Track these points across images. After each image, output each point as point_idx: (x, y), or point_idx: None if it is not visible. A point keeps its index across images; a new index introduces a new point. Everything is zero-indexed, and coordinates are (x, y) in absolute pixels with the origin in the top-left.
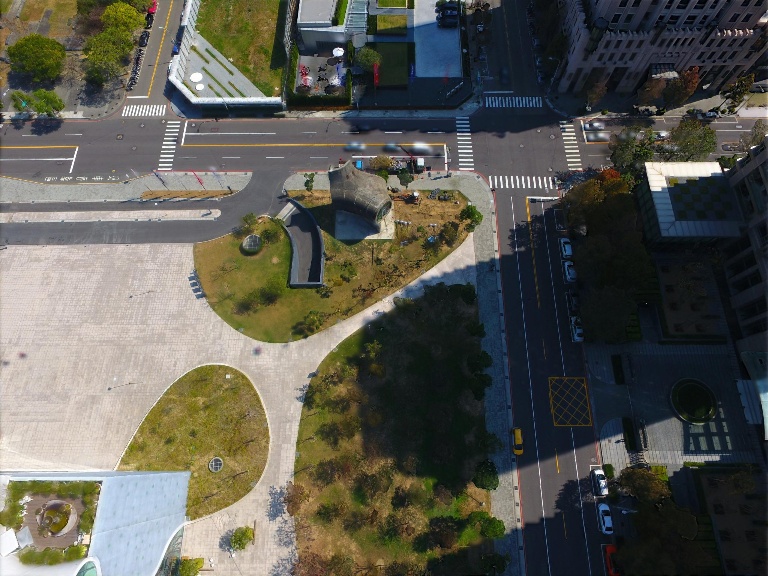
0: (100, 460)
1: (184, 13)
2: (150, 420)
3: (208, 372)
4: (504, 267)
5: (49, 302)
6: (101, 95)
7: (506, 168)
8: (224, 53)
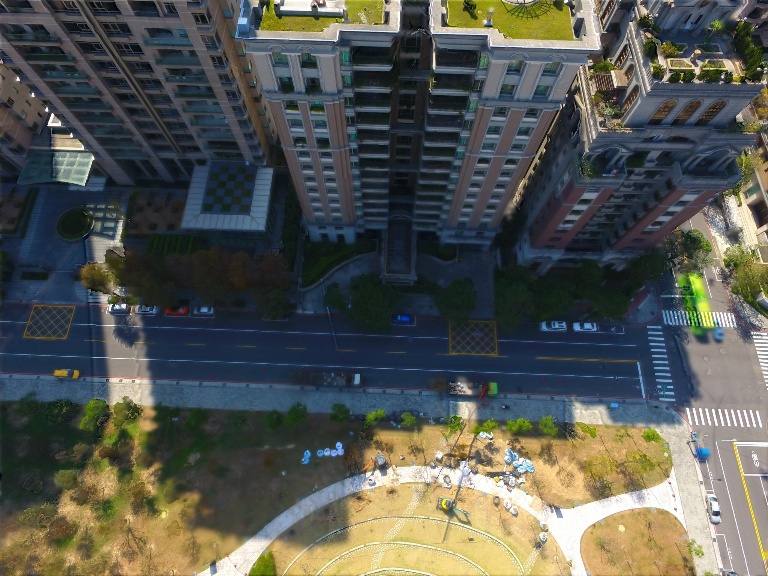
0: None
1: None
2: None
3: None
4: None
5: None
6: None
7: None
8: None
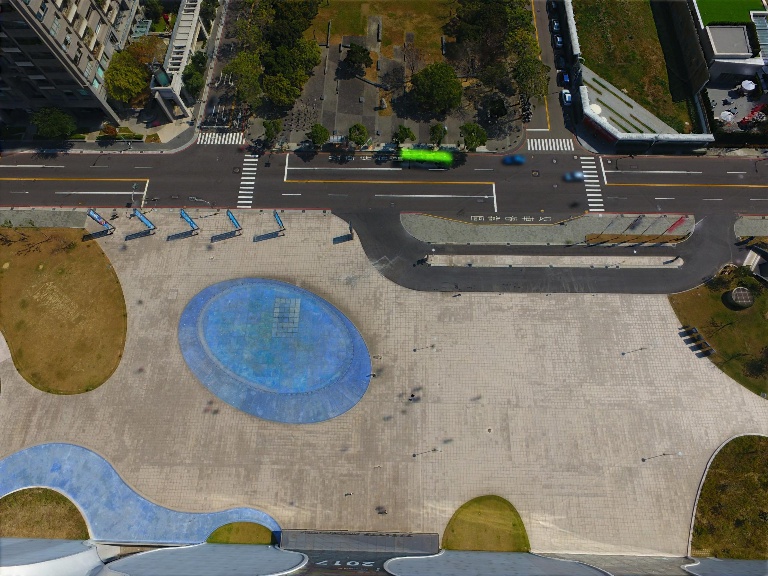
0: (667, 543)
1: (572, 40)
2: (707, 498)
3: (751, 444)
4: None
5: (534, 358)
6: (498, 127)
7: None
8: (615, 83)
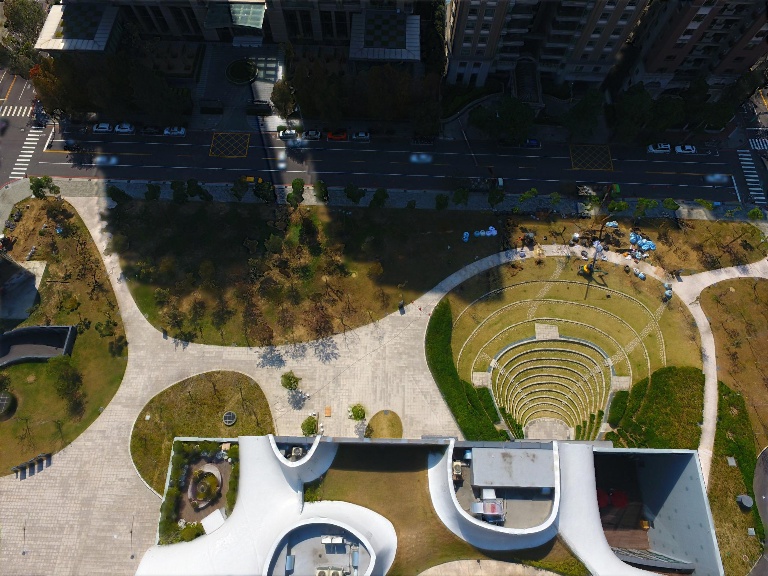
0: None
1: None
2: None
3: (138, 439)
4: (107, 176)
5: None
6: None
7: (6, 163)
8: None
